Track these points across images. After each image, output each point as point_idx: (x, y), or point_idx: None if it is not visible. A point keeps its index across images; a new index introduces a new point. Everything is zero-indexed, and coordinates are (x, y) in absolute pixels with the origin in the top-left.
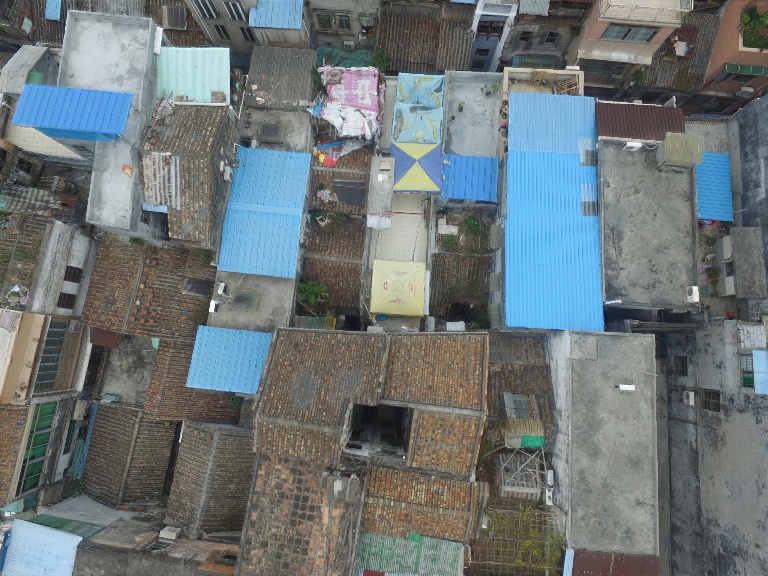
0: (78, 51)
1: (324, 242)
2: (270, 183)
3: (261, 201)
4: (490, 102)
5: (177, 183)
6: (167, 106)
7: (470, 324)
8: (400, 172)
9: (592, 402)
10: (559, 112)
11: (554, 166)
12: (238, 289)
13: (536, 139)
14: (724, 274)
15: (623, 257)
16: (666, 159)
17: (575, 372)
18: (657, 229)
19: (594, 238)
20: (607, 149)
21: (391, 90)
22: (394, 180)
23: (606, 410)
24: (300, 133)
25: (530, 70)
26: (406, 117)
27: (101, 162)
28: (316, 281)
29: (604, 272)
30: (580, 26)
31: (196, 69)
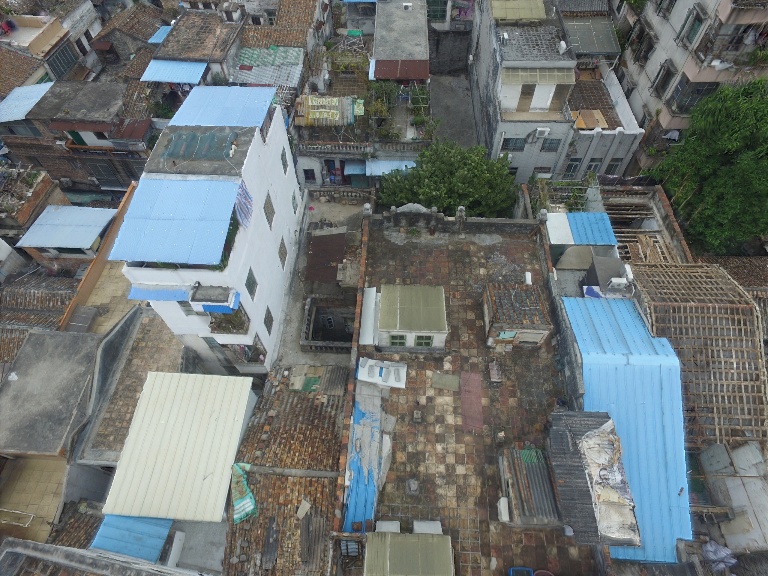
0: None
1: None
2: None
3: None
4: None
5: None
6: None
7: None
8: None
9: (389, 15)
10: None
11: None
12: None
13: None
14: None
15: None
16: None
17: (380, 7)
18: None
19: None
20: None
21: None
22: None
23: (398, 17)
24: None
25: None
26: None
27: None
28: None
29: None
30: None
31: None
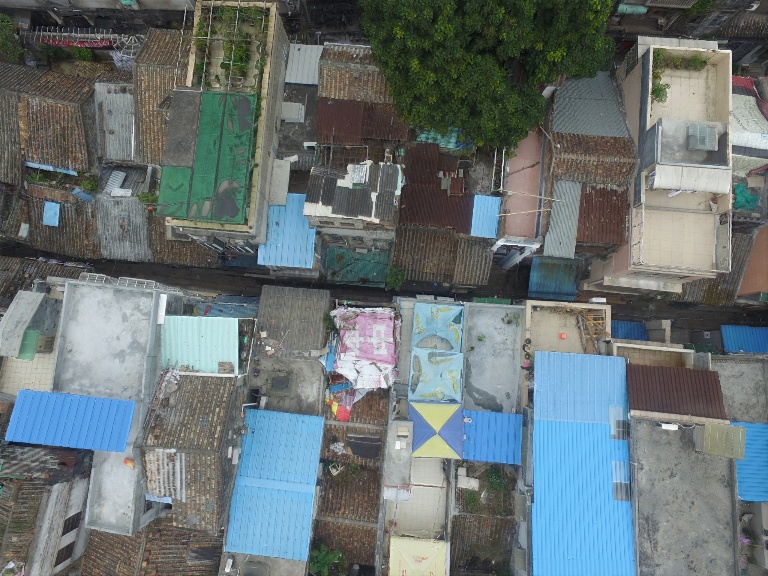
0: (77, 321)
1: (337, 497)
2: (281, 453)
3: (271, 475)
4: (511, 329)
5: (182, 477)
6: (171, 380)
7: (491, 575)
8: (419, 439)
9: None
10: (588, 375)
11: (583, 439)
12: (247, 566)
13: (564, 406)
14: (763, 544)
15: (659, 551)
16: (705, 453)
17: None
18: (695, 519)
19: (627, 528)
20: (640, 425)
21: (406, 312)
22: (412, 447)
23: None
24: (312, 383)
25: (554, 304)
26: (424, 368)
27: (101, 452)
28: (329, 540)
29: (639, 572)
30: (606, 254)
31: (202, 338)
